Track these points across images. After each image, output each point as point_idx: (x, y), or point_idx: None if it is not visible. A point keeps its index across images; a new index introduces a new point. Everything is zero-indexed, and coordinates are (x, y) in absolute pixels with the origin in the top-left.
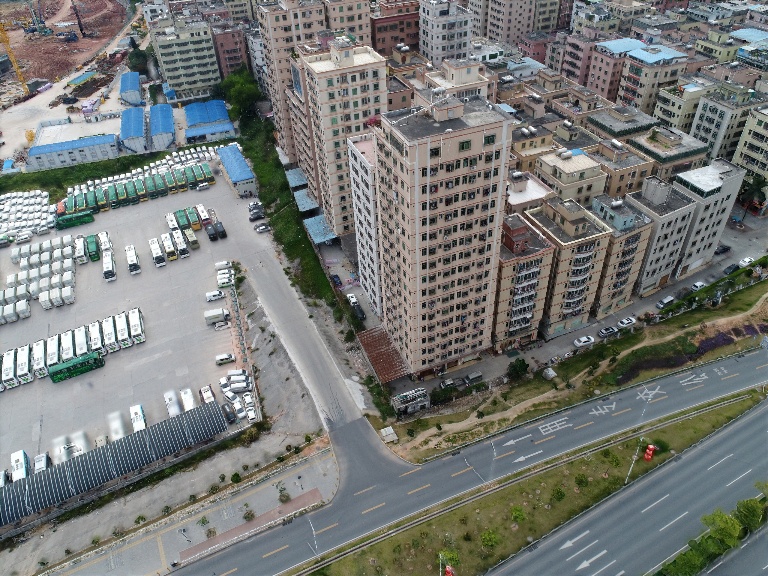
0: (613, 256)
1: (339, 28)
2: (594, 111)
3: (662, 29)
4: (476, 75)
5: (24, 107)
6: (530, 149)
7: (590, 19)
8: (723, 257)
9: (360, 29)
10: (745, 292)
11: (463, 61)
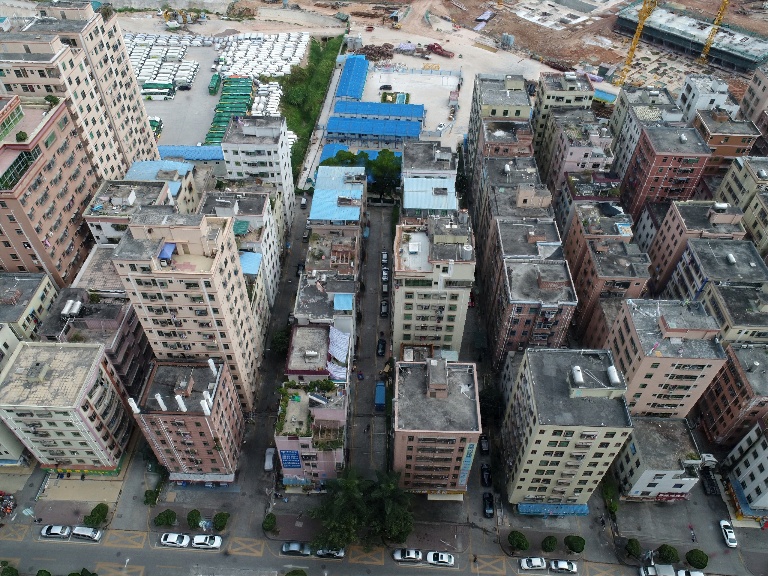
0: None
1: None
2: None
3: None
4: None
5: (532, 67)
6: None
7: None
8: None
9: None
10: None
11: None
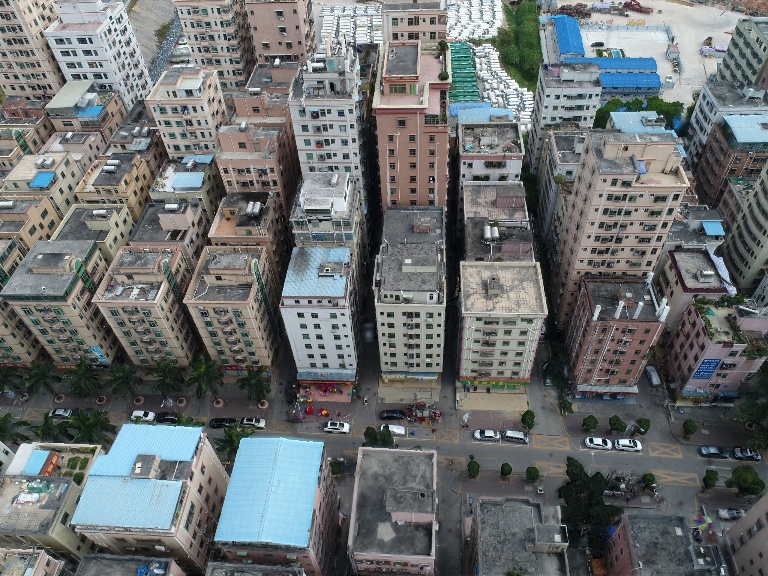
0: None
1: None
2: (110, 269)
3: None
4: None
5: None
6: None
7: (510, 575)
8: None
9: None
10: None
11: (180, 76)
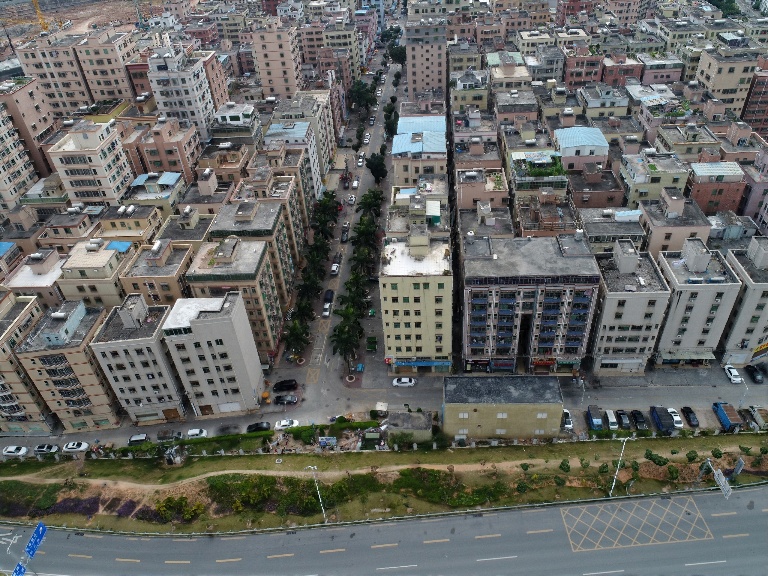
0: (31, 371)
1: (91, 70)
2: None
3: (513, 110)
4: (97, 141)
5: None
6: (124, 230)
7: (450, 86)
8: (277, 409)
9: (113, 73)
10: (216, 460)
11: (90, 125)
